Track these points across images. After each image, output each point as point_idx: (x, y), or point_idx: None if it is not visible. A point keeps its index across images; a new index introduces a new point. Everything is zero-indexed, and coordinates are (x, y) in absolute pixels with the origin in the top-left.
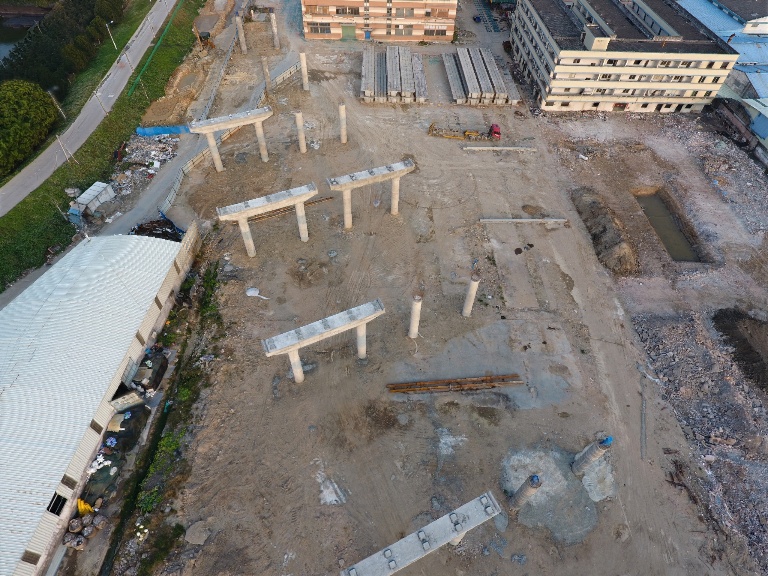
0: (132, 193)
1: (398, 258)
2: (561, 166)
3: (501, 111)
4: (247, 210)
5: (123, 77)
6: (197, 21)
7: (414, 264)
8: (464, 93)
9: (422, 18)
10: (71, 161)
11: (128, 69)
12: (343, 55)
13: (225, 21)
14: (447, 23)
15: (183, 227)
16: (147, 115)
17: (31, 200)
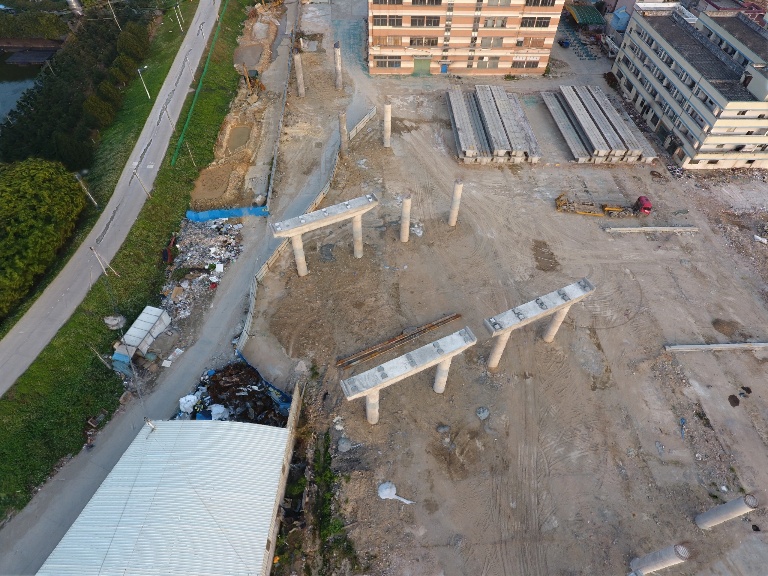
0: (192, 315)
1: (574, 419)
2: (737, 254)
3: (633, 171)
4: (384, 382)
5: (162, 138)
6: (238, 54)
7: (600, 429)
8: (585, 149)
9: (512, 48)
10: (109, 273)
11: (167, 126)
12: (420, 96)
13: (270, 52)
14: (541, 53)
15: (270, 373)
16: (196, 190)
17: (60, 343)
